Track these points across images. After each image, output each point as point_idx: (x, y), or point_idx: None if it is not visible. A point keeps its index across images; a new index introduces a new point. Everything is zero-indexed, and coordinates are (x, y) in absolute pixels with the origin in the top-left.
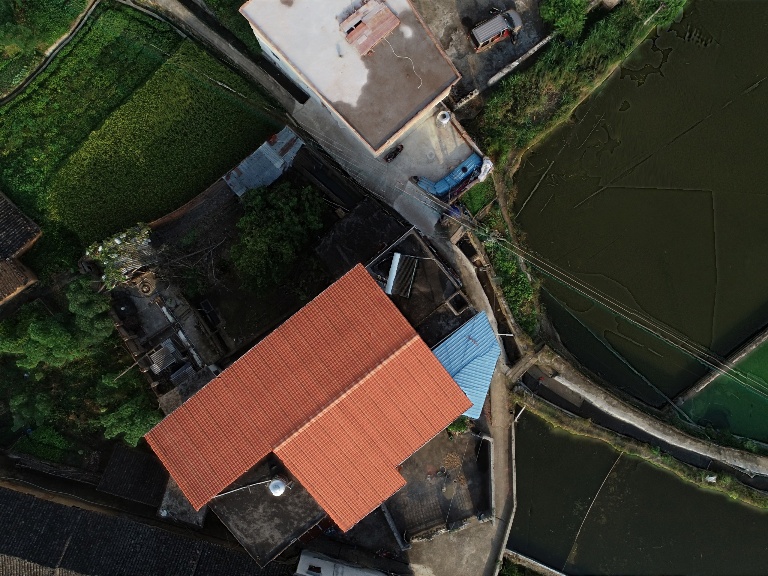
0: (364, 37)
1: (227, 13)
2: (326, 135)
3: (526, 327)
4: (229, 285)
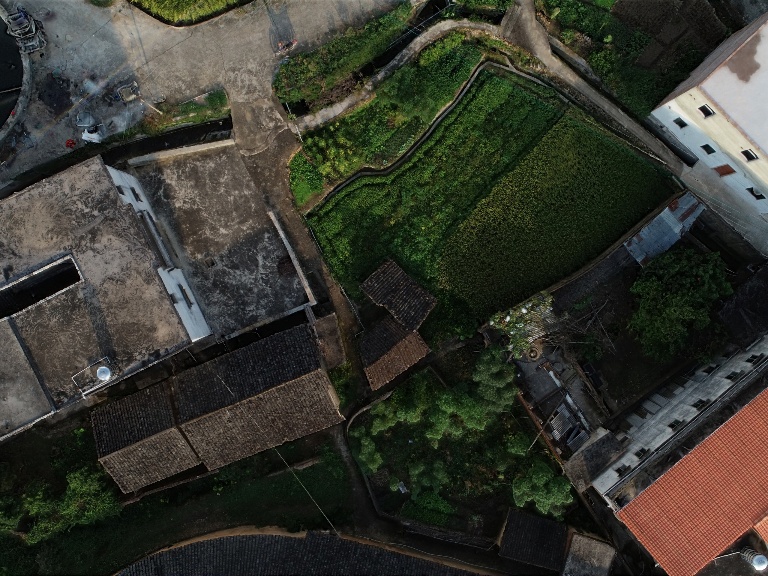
0: None
1: (617, 78)
2: (714, 197)
3: None
4: (611, 347)
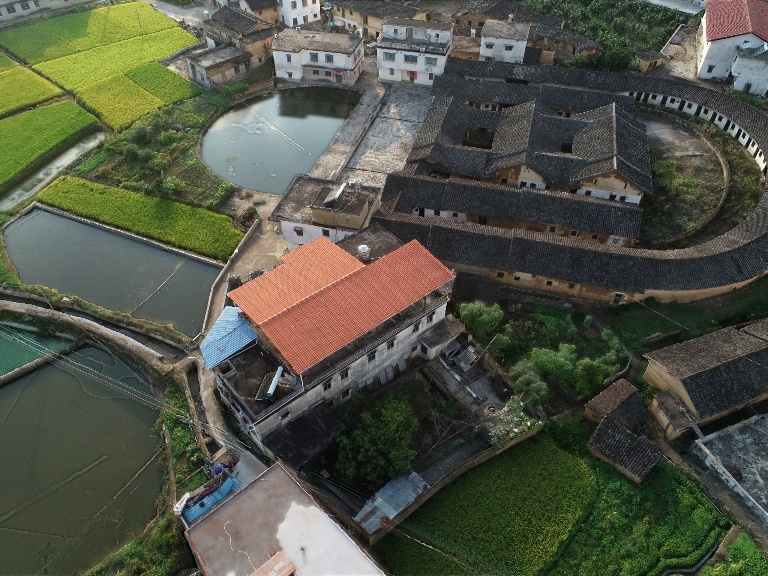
0: (277, 569)
1: None
2: None
3: (176, 389)
4: None
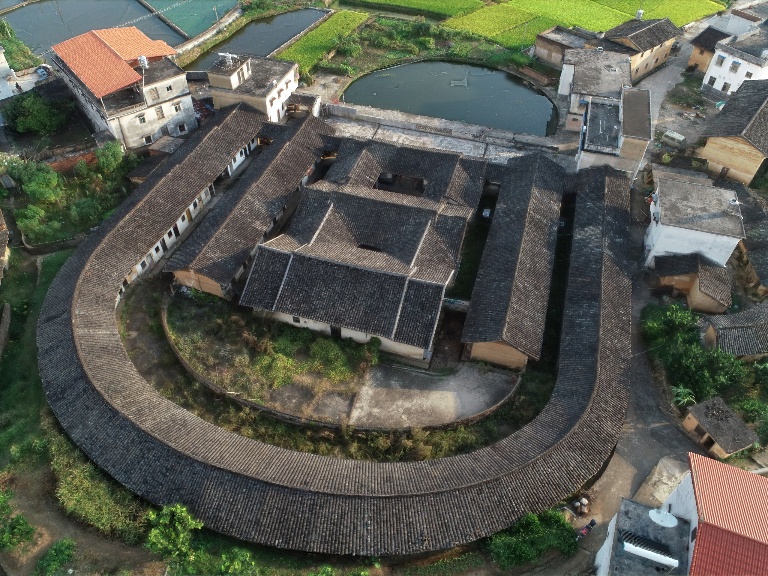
0: None
1: None
2: None
3: None
4: None
